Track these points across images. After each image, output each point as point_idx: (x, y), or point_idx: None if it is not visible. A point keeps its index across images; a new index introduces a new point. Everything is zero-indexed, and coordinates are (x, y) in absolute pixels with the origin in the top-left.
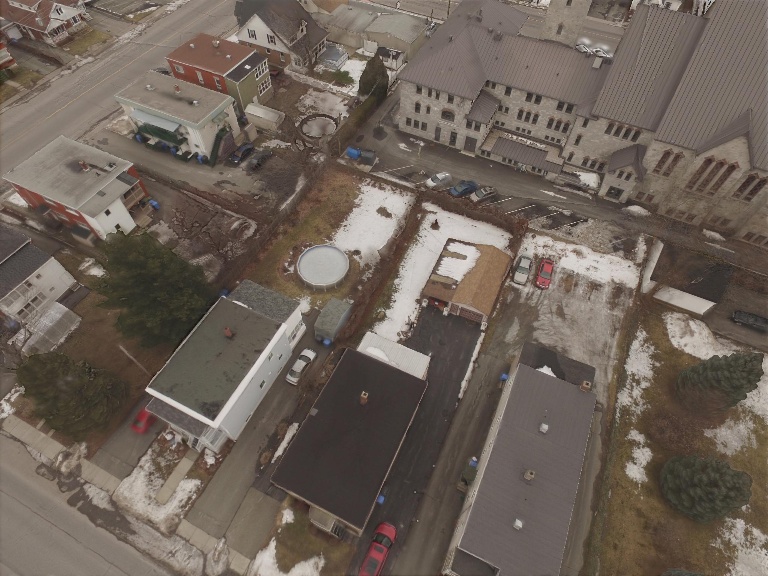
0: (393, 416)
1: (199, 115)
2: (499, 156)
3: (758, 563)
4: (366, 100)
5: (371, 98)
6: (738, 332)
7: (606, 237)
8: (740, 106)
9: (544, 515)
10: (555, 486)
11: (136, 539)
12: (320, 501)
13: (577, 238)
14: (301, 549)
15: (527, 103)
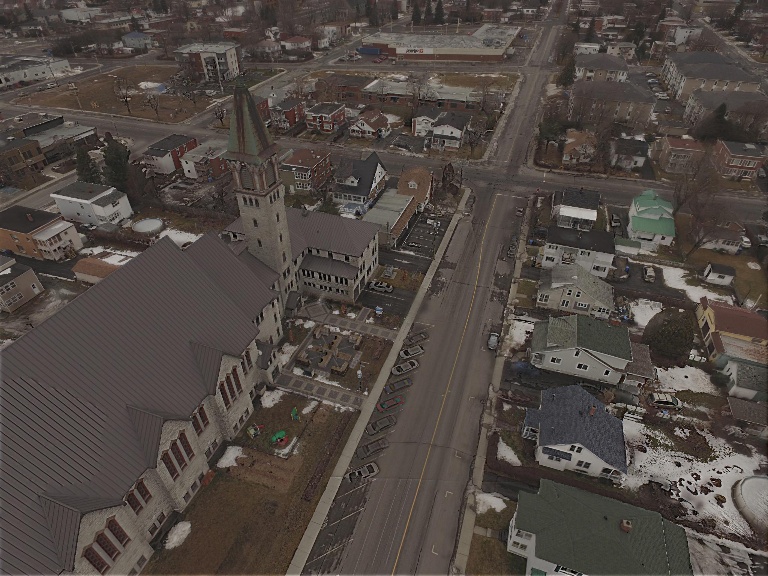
0: None
1: None
2: None
3: None
4: None
5: None
6: None
7: None
8: None
9: None
10: None
11: (42, 208)
12: None
13: None
14: None
15: None
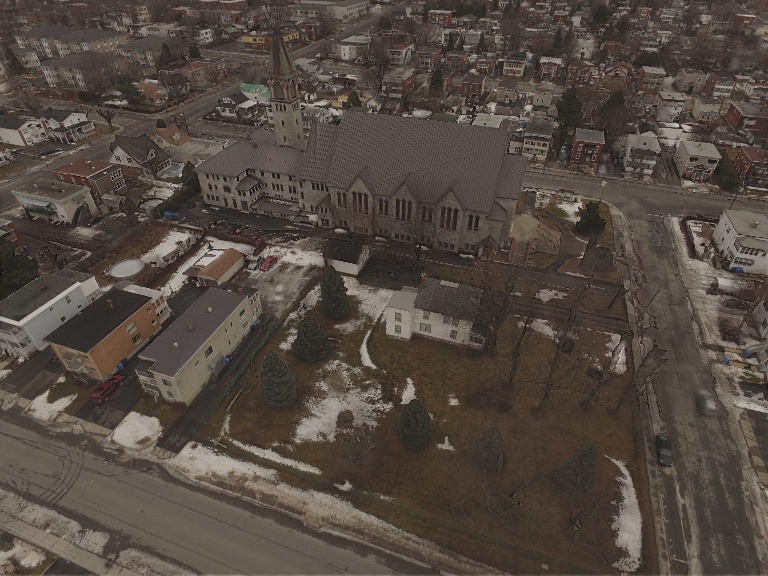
0: (126, 312)
1: (63, 197)
2: (261, 210)
3: (339, 377)
4: (185, 188)
5: (189, 187)
6: (374, 281)
7: (314, 244)
8: (362, 164)
9: (193, 342)
10: (205, 331)
11: None
12: (68, 345)
13: (295, 246)
14: (65, 393)
15: (274, 179)
